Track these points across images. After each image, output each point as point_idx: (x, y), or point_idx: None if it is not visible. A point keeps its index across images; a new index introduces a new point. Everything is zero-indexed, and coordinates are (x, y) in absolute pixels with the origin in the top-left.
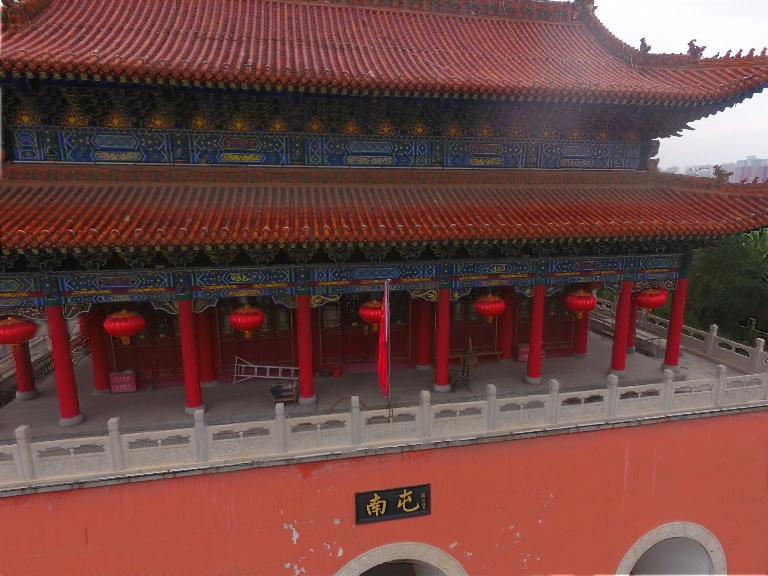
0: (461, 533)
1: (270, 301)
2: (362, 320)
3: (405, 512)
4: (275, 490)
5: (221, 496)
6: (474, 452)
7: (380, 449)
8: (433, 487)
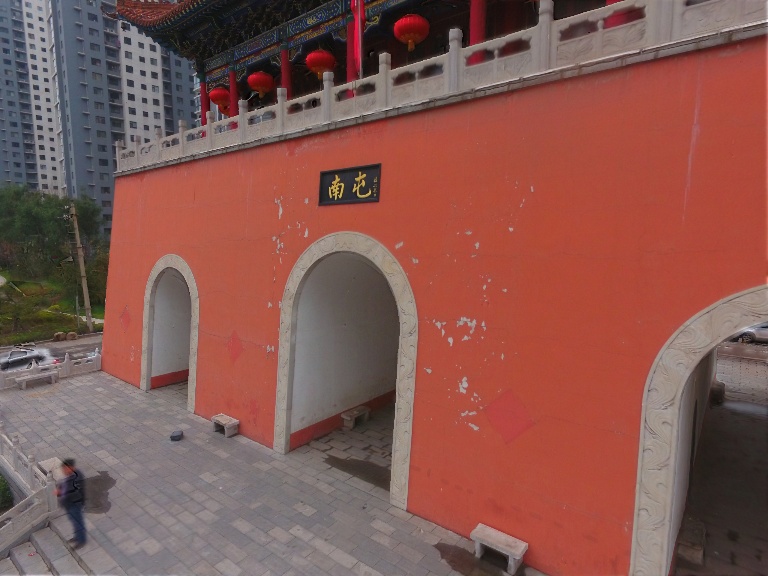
0: (409, 232)
1: (332, 39)
2: (396, 37)
3: (358, 198)
4: (273, 167)
5: (247, 171)
6: (429, 124)
7: (339, 122)
8: (384, 169)
